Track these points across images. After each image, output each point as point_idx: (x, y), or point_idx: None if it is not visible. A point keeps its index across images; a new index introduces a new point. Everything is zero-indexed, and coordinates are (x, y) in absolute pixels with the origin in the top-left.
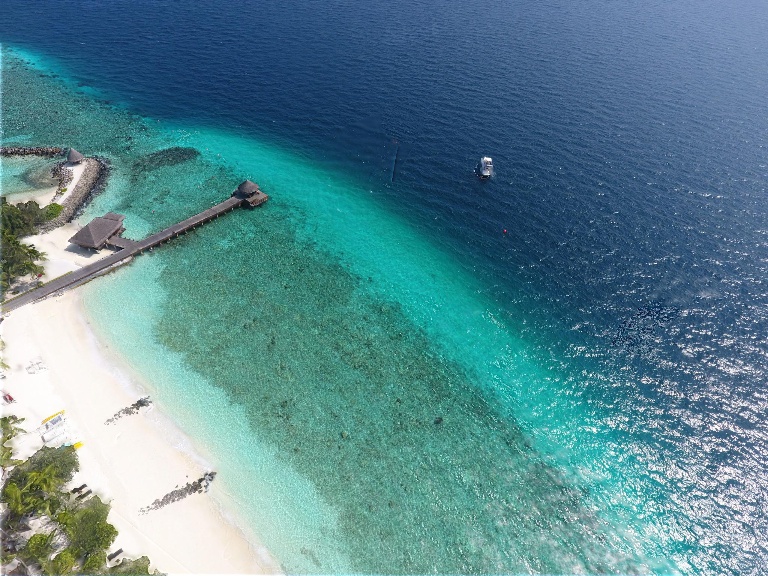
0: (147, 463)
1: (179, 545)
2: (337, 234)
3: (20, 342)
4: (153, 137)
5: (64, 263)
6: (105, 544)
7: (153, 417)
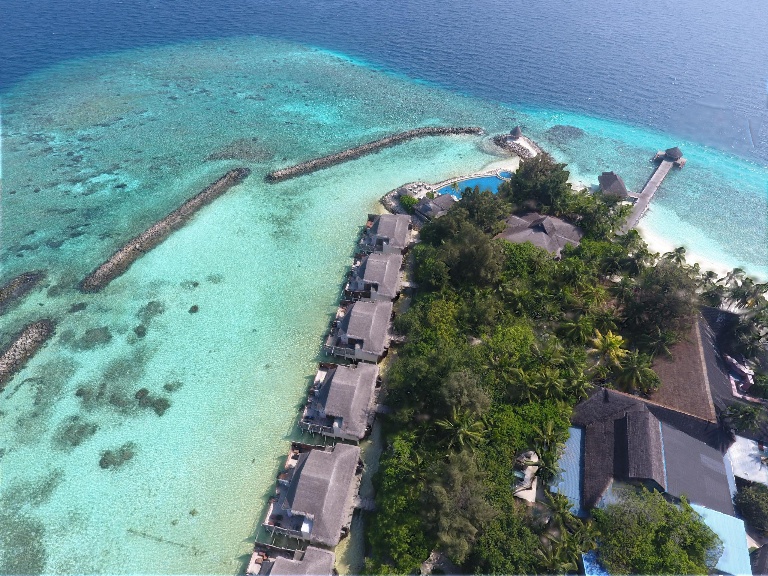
0: None
1: None
2: (759, 187)
3: None
4: (530, 118)
5: None
6: None
7: None
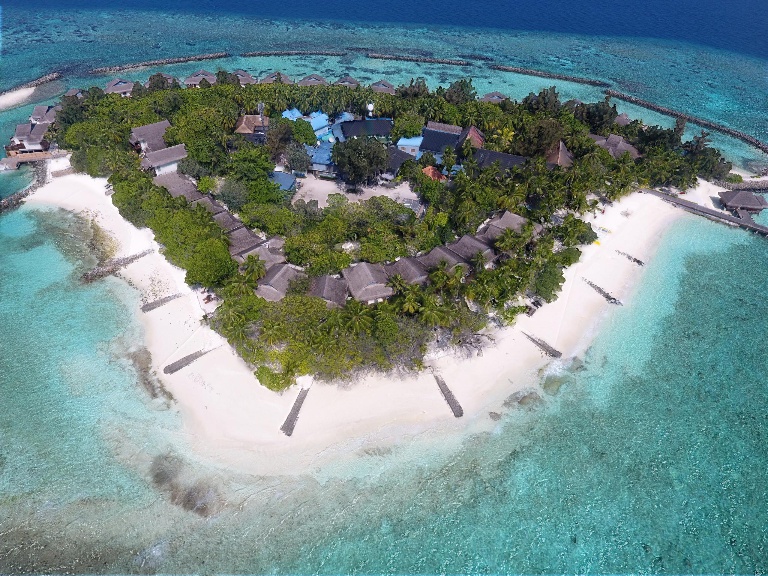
0: (607, 273)
1: (576, 297)
2: None
3: (634, 204)
4: None
5: (700, 199)
6: (563, 262)
7: (634, 269)
